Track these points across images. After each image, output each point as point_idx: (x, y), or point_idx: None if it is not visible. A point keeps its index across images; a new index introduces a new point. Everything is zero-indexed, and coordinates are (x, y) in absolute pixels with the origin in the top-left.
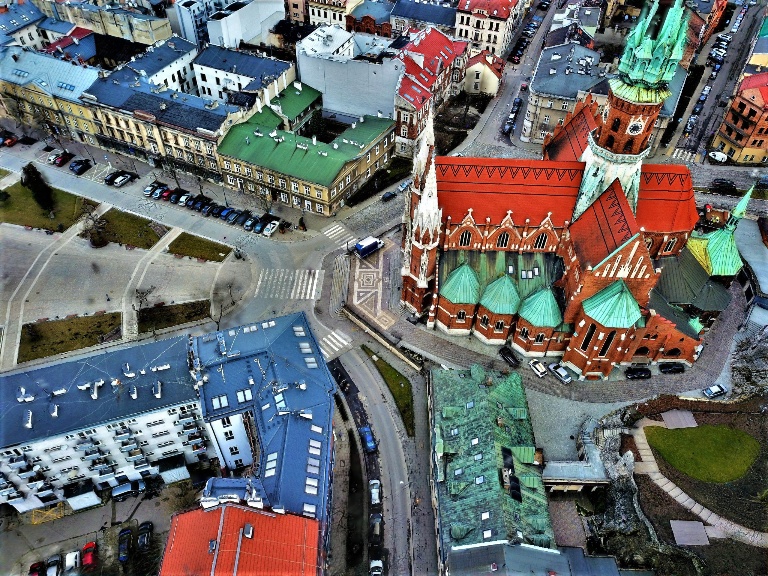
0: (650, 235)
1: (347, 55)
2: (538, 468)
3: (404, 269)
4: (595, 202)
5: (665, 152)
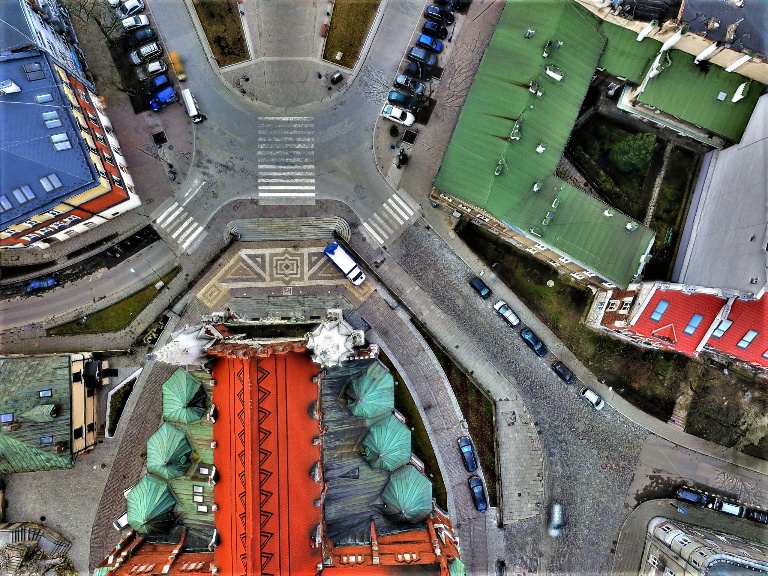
0: None
1: None
2: None
3: None
4: None
5: None
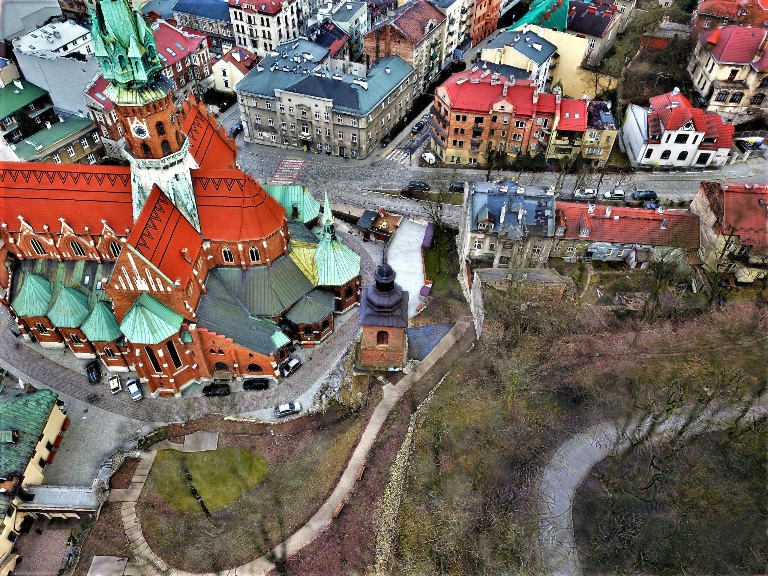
0: (222, 244)
1: (87, 52)
2: (4, 496)
3: None
4: None
5: (381, 153)
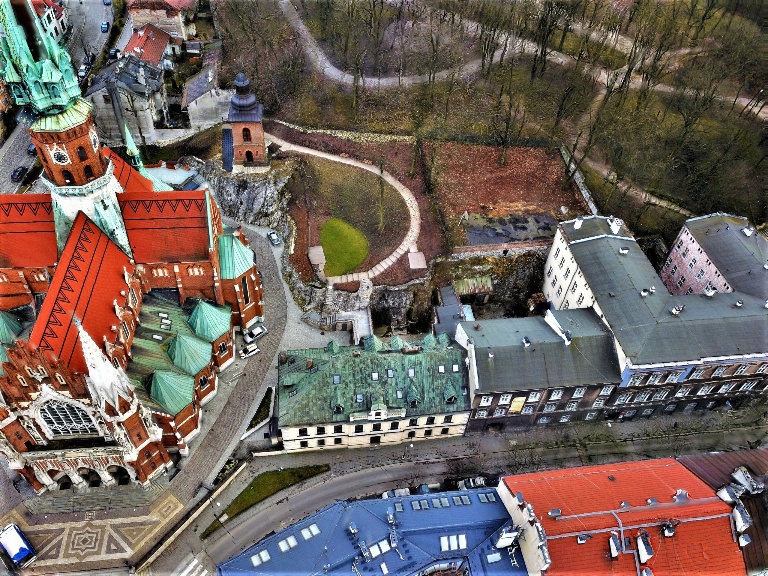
0: None
1: None
2: None
3: (132, 454)
4: (126, 225)
5: None
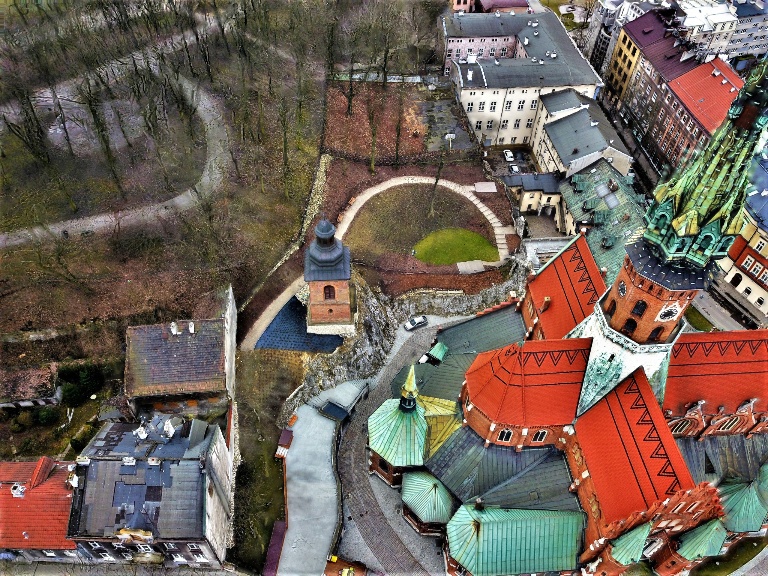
0: None
1: None
2: None
3: None
4: None
5: None
